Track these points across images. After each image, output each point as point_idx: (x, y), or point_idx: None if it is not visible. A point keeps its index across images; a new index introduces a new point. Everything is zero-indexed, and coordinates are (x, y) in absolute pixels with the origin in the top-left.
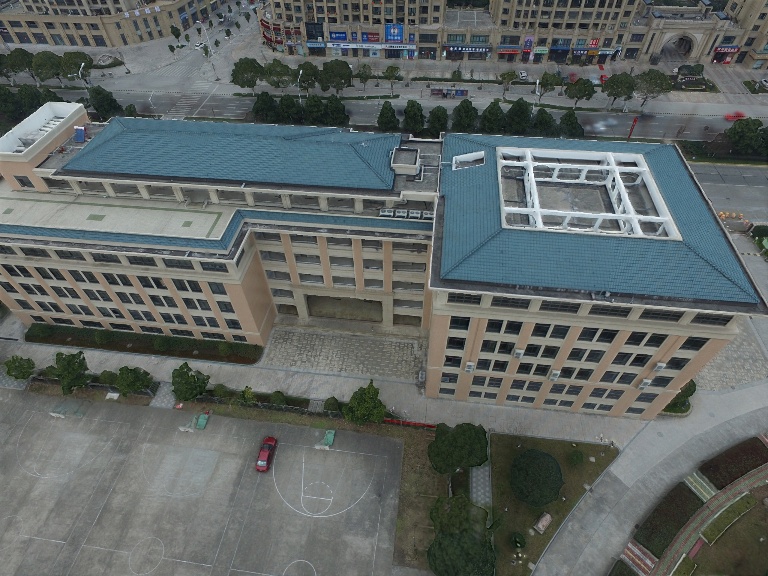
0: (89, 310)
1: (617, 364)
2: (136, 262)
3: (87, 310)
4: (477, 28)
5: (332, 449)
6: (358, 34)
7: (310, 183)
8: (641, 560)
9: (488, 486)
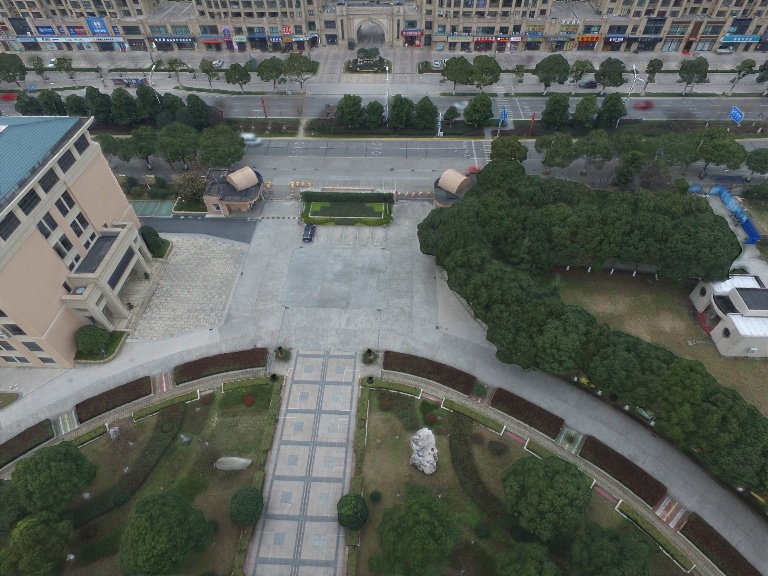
0: None
1: None
2: None
3: None
4: (177, 19)
5: None
6: (64, 28)
7: None
8: None
9: None
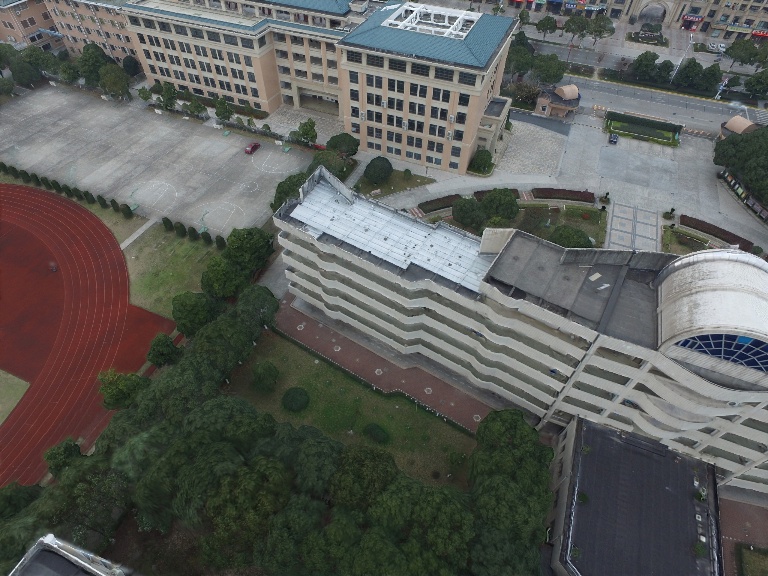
0: (184, 76)
1: (434, 118)
2: (211, 39)
3: (183, 76)
4: None
5: (286, 154)
6: None
7: (304, 6)
8: (416, 214)
9: (357, 179)
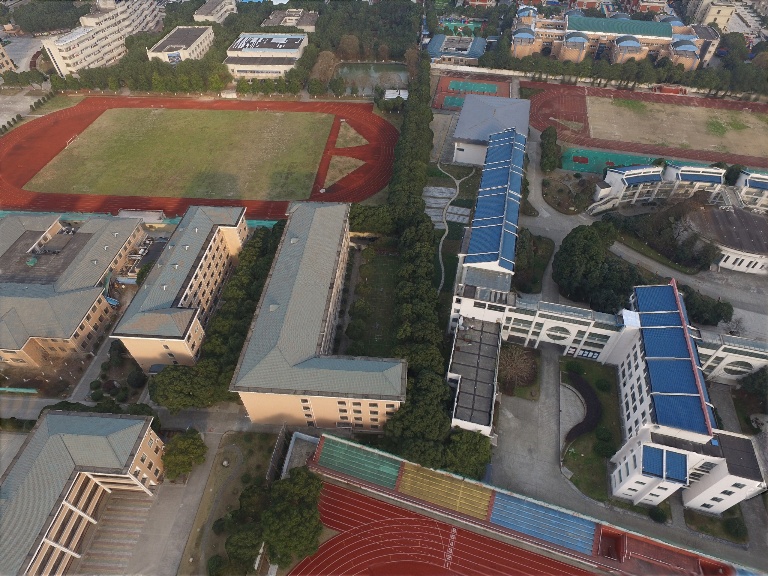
0: None
1: None
2: None
3: None
4: None
5: None
6: None
7: None
8: None
9: None
